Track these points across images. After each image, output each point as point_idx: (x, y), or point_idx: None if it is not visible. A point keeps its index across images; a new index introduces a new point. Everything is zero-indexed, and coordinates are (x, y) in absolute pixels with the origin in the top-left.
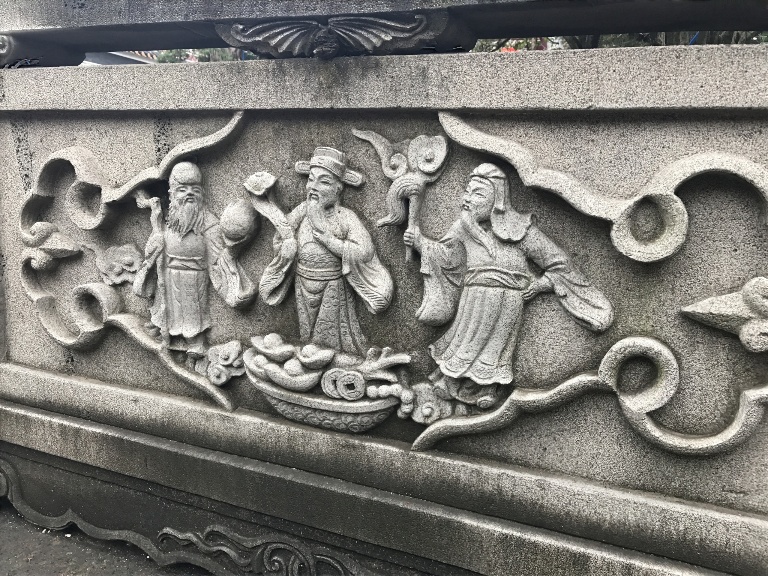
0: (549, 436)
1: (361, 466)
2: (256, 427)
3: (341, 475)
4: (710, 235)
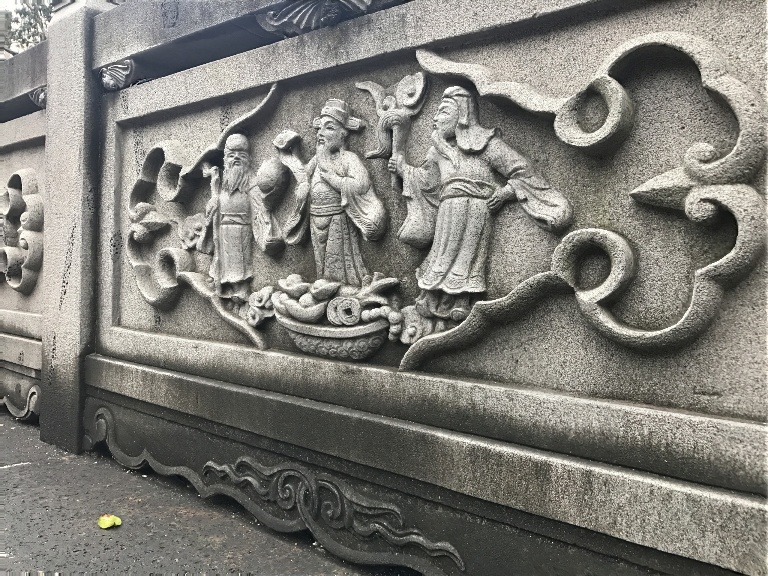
0: (520, 347)
1: (358, 391)
2: (279, 361)
3: (343, 402)
4: (657, 117)
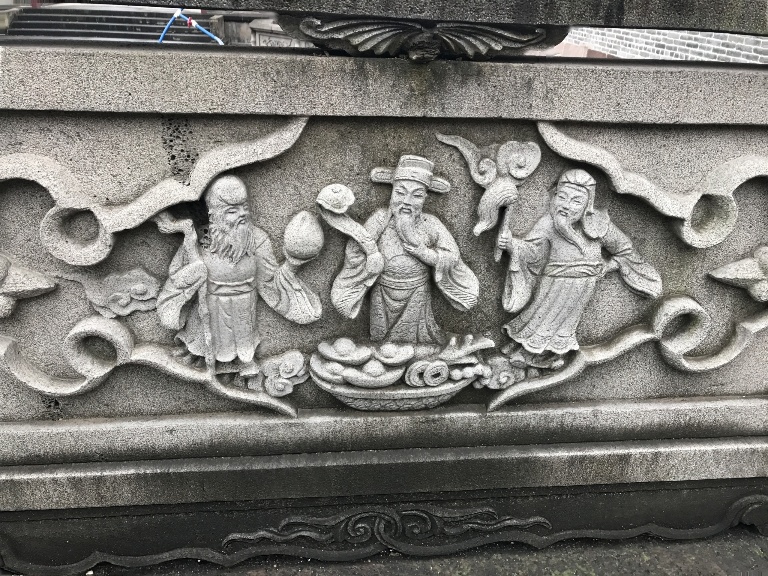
0: (599, 377)
1: (440, 434)
2: (329, 426)
3: (420, 445)
4: None
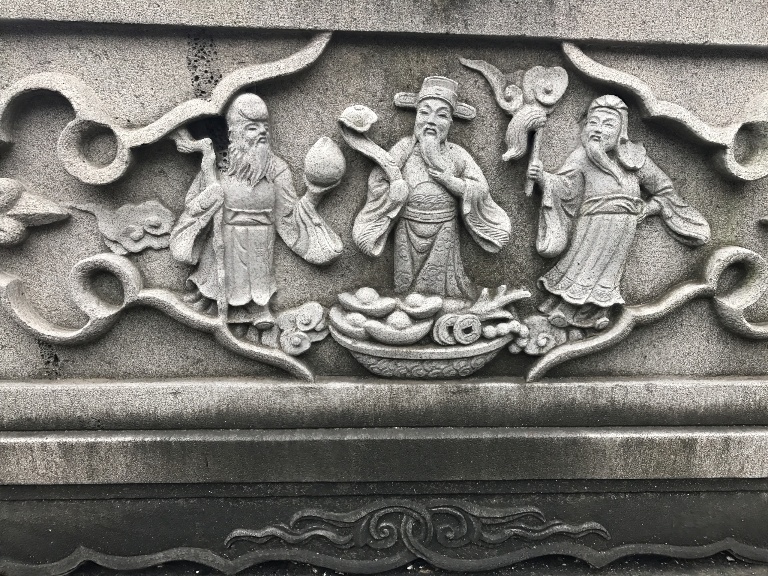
0: (650, 345)
1: (474, 409)
2: (349, 393)
3: (452, 422)
4: None
